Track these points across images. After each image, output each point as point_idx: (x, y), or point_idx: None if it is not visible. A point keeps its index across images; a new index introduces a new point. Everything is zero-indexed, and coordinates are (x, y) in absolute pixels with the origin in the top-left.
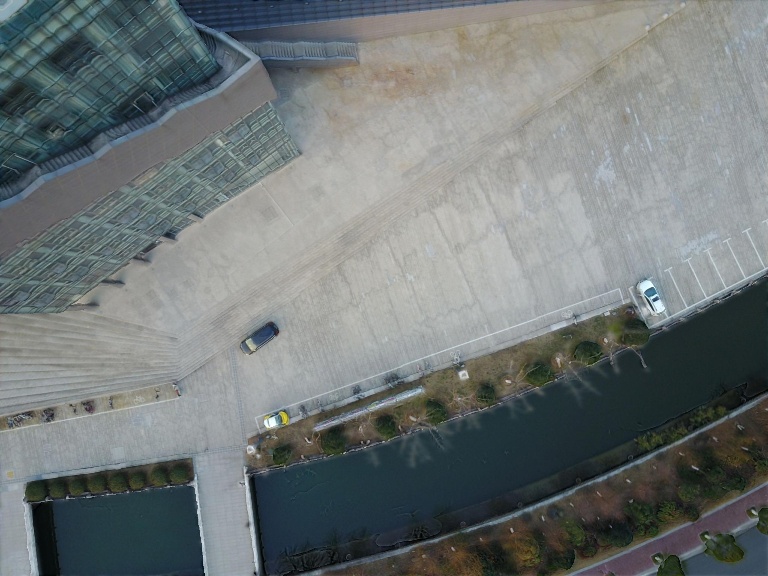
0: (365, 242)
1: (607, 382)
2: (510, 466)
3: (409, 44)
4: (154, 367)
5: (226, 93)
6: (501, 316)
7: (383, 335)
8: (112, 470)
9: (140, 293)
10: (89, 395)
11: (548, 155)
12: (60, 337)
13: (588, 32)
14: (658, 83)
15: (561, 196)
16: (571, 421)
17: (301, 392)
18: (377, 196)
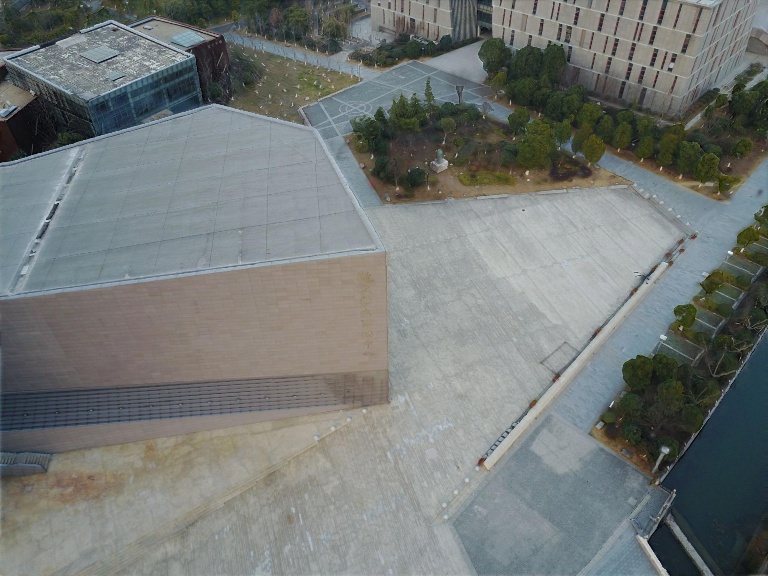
0: None
1: None
2: None
3: (99, 454)
4: None
5: None
6: None
7: None
8: None
9: None
10: None
11: (206, 557)
12: None
13: (263, 442)
14: (324, 485)
15: None
16: None
17: None
18: None
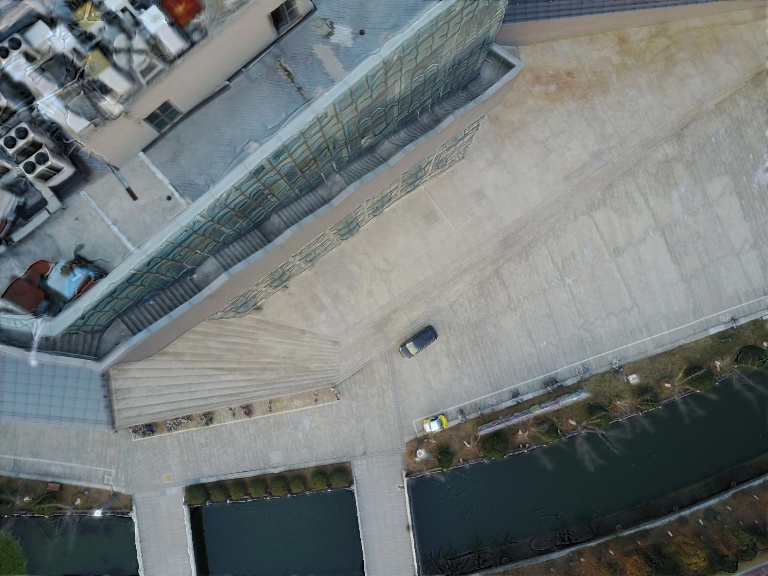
0: (524, 246)
1: (748, 385)
2: (661, 469)
3: (569, 47)
4: (314, 371)
5: (487, 100)
6: (659, 320)
7: (541, 339)
8: (270, 474)
9: (303, 297)
10: (250, 399)
11: (707, 159)
12: (222, 341)
13: (748, 35)
14: None
15: (720, 200)
16: (718, 424)
17: (459, 396)
18: (538, 200)
